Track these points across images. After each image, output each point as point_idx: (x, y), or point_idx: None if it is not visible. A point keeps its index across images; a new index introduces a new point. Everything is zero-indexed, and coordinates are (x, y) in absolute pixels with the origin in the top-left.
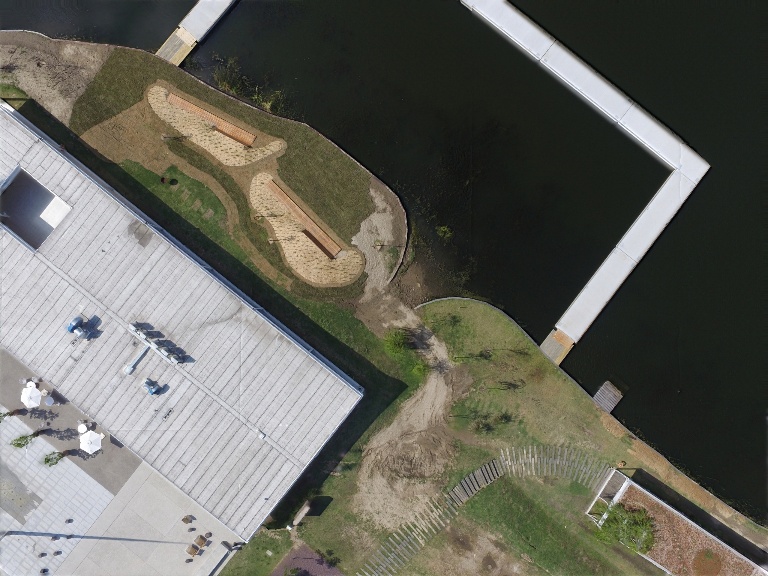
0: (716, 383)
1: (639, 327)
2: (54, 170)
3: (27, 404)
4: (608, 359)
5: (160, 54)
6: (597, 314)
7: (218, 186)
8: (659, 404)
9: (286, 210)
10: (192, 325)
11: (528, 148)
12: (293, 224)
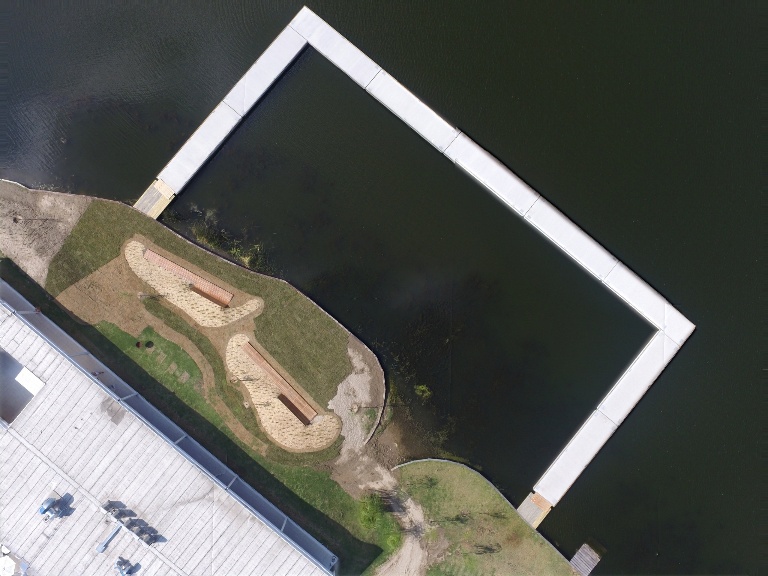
0: (695, 546)
1: (618, 489)
2: (27, 345)
3: (1, 573)
4: (586, 521)
5: (138, 206)
6: (576, 477)
7: (194, 348)
8: (637, 567)
9: (262, 373)
10: (164, 504)
11: (510, 306)
12: (269, 389)
